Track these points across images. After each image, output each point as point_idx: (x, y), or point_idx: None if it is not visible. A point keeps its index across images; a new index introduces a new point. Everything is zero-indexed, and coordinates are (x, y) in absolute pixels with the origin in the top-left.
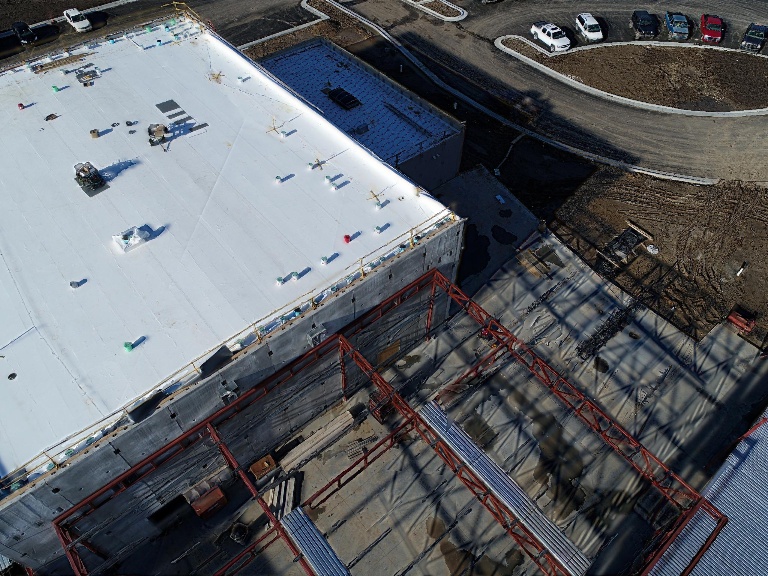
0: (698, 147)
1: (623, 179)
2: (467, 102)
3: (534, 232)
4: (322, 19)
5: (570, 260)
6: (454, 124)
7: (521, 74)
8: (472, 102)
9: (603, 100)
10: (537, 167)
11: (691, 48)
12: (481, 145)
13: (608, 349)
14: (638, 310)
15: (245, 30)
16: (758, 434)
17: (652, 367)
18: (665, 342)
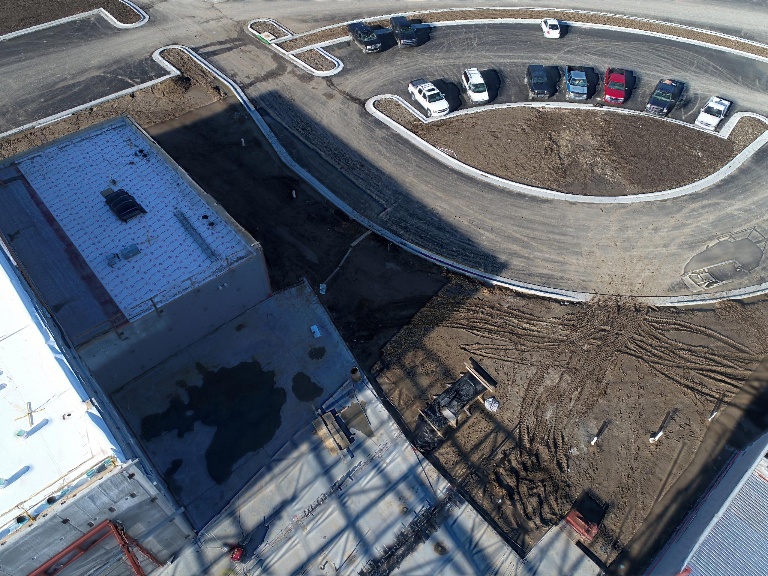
0: (576, 247)
1: (476, 296)
2: (313, 186)
3: (346, 382)
4: (171, 75)
5: (382, 425)
6: (248, 243)
7: (387, 147)
8: (319, 186)
9: (475, 182)
10: (374, 280)
11: (590, 110)
12: (313, 249)
13: (401, 574)
14: (453, 506)
15: (76, 90)
16: None
17: None
18: (479, 559)
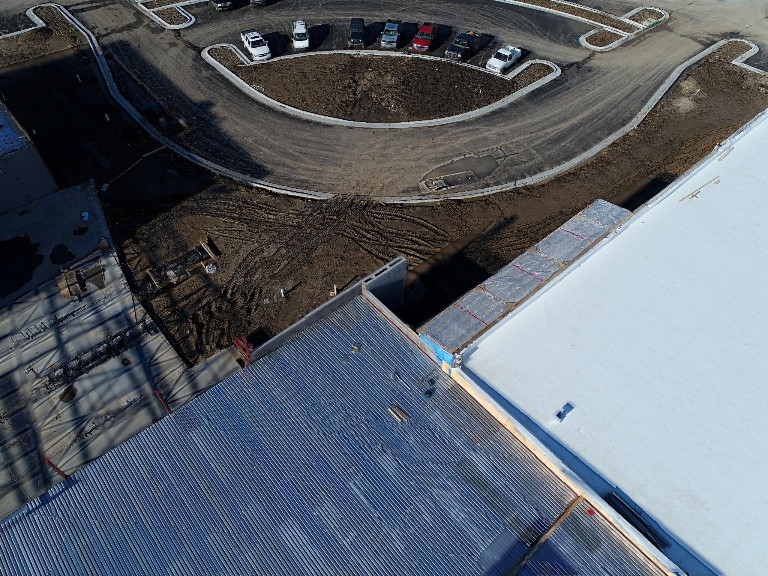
0: (338, 160)
1: (233, 194)
2: (129, 113)
3: (96, 251)
4: (37, 27)
5: (114, 281)
6: (22, 139)
7: (207, 84)
8: (134, 113)
9: (273, 111)
10: (151, 182)
11: (399, 57)
12: (109, 159)
13: (88, 377)
14: (148, 334)
15: None
16: (85, 474)
17: (121, 396)
18: (154, 369)
